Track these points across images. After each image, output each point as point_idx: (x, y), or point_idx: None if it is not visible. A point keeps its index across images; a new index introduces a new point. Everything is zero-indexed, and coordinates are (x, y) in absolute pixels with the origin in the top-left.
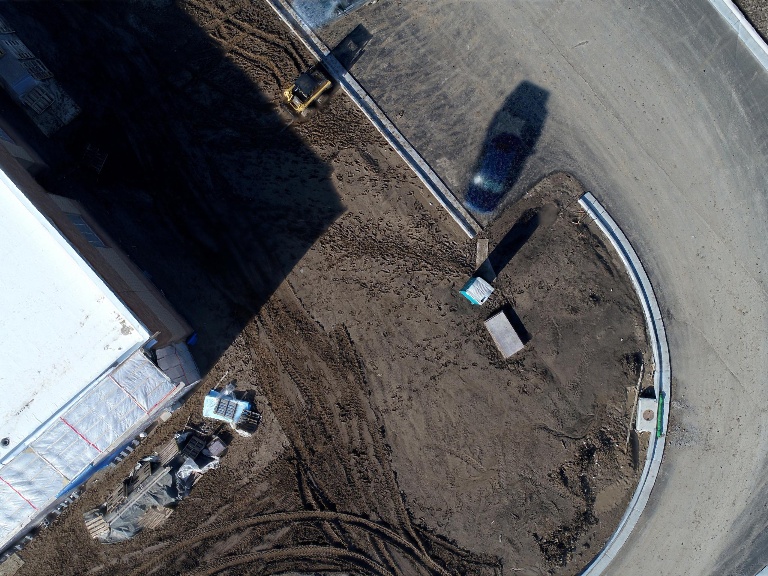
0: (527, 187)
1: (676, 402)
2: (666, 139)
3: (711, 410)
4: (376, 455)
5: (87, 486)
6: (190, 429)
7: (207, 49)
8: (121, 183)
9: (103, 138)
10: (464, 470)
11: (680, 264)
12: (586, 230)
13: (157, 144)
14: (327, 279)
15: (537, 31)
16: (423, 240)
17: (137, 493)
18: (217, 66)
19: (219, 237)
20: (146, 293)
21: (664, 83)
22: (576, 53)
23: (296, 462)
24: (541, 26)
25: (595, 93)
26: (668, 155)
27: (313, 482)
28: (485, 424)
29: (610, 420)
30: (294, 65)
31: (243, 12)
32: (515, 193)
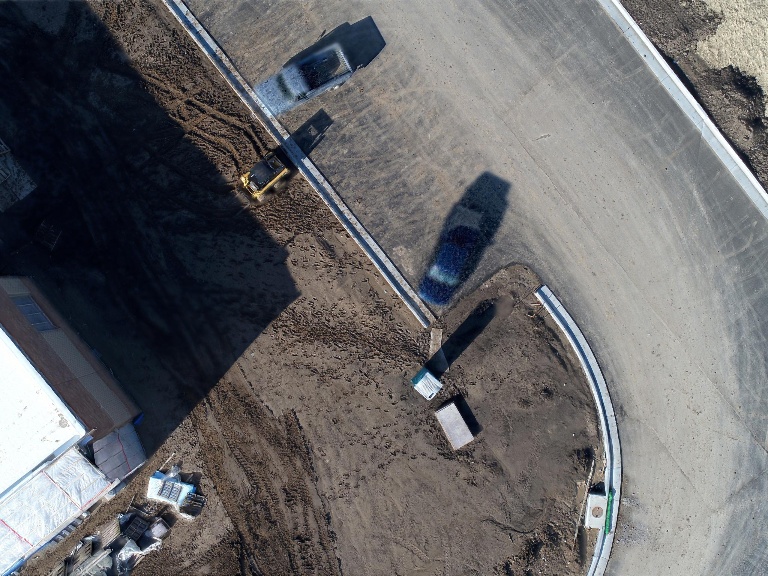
0: (483, 278)
1: (626, 500)
2: (625, 235)
3: (661, 509)
4: (321, 542)
5: (28, 563)
6: (134, 509)
7: (166, 129)
8: (74, 260)
9: (57, 214)
10: (409, 560)
11: (635, 361)
12: (541, 323)
13: (112, 222)
14: (278, 363)
15: (499, 122)
16: (376, 328)
17: (76, 574)
18: (175, 146)
19: (170, 318)
20: (92, 376)
21: (625, 179)
22: (538, 146)
23: (240, 546)
24: (503, 118)
25: (555, 187)
26: (627, 252)
27: (256, 567)
28: (432, 514)
29: (559, 515)
30: (253, 148)
31: (204, 93)
32: (471, 284)
